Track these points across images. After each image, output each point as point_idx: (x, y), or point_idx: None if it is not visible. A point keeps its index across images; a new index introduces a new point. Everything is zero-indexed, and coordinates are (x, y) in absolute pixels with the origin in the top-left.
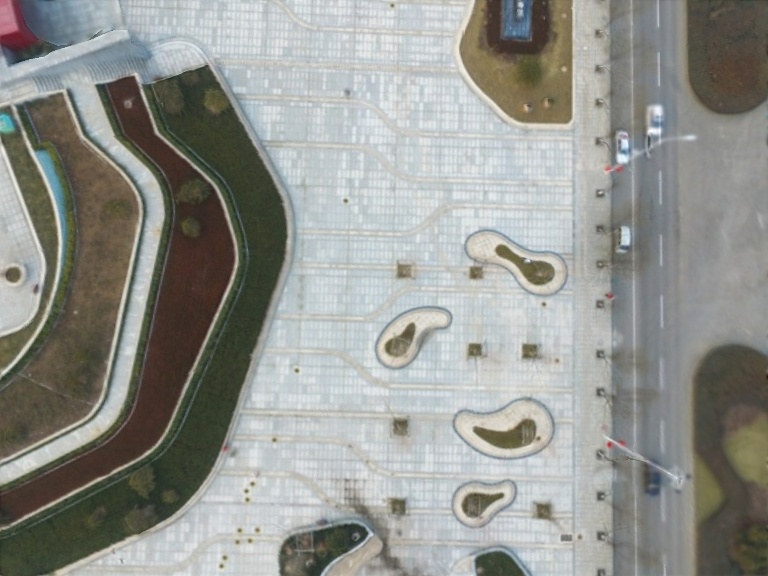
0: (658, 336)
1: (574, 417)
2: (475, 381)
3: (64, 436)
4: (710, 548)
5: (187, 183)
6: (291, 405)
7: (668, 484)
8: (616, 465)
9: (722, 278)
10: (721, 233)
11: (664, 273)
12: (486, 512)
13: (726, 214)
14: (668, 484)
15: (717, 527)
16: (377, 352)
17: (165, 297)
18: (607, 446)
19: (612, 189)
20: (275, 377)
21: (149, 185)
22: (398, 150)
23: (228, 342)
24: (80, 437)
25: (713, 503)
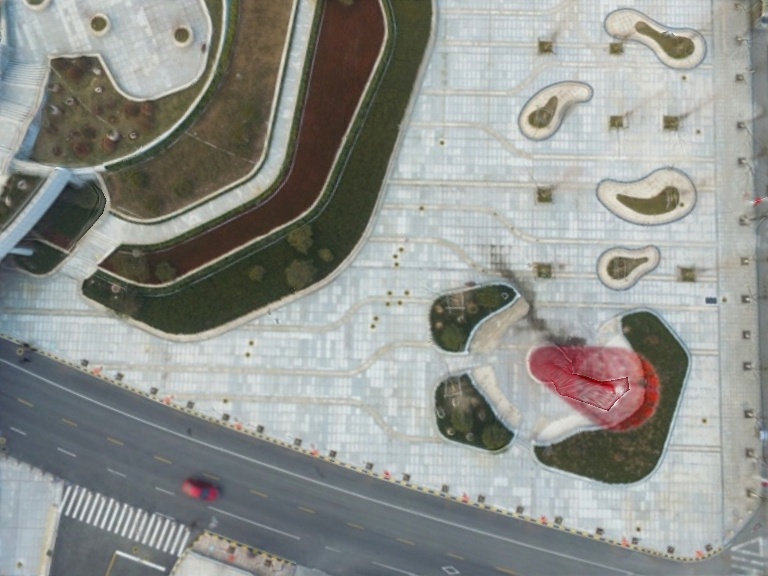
0: None
1: (716, 185)
2: (617, 151)
3: (227, 193)
4: None
5: None
6: (437, 175)
7: None
8: (759, 231)
9: None
10: None
11: None
12: (631, 275)
13: None
14: None
15: None
16: (520, 125)
17: (320, 65)
18: (753, 208)
19: None
20: (421, 149)
21: None
22: None
23: (378, 112)
24: (242, 195)
25: None
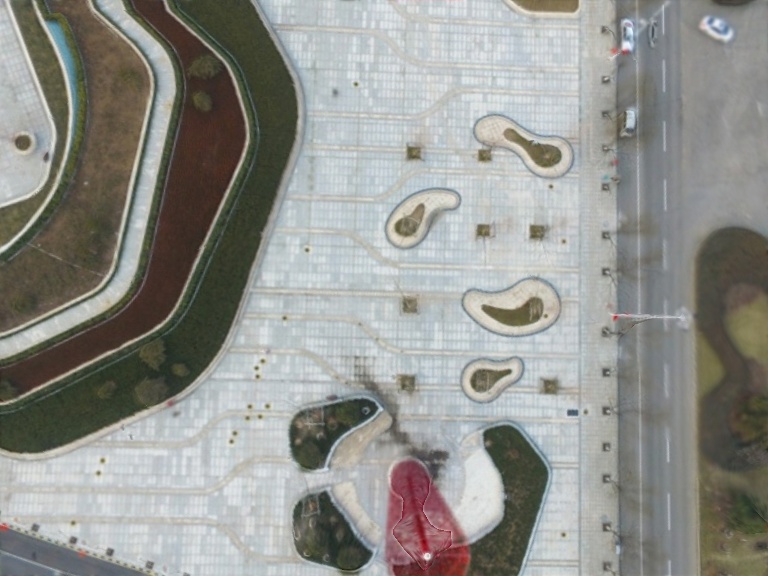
0: (662, 219)
1: (580, 296)
2: (483, 261)
3: (74, 307)
4: (712, 421)
5: (198, 58)
6: (301, 284)
7: (671, 361)
8: (621, 342)
9: (723, 164)
10: (722, 121)
11: (667, 158)
12: (494, 388)
13: (727, 102)
14: (671, 361)
15: (719, 401)
16: (387, 232)
17: (176, 172)
18: (613, 321)
19: (617, 76)
20: (285, 256)
21: (160, 60)
22: (408, 35)
23: (239, 219)
24: (90, 309)
25: (715, 379)
